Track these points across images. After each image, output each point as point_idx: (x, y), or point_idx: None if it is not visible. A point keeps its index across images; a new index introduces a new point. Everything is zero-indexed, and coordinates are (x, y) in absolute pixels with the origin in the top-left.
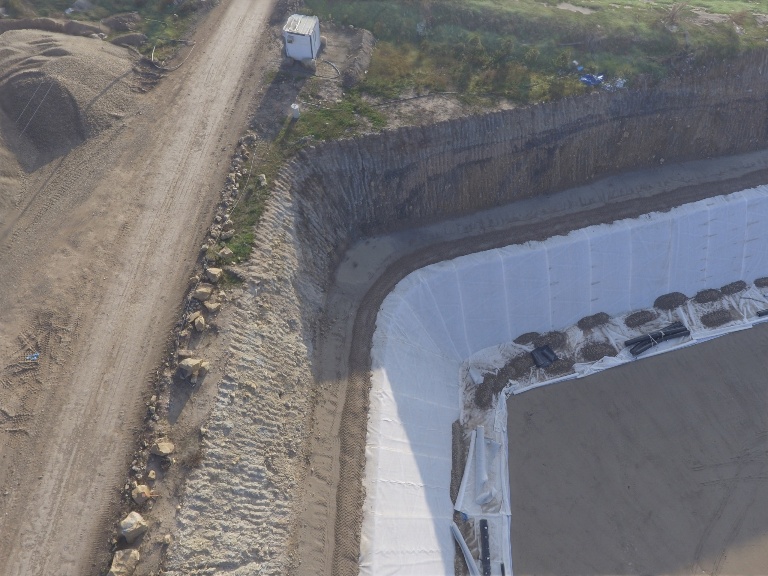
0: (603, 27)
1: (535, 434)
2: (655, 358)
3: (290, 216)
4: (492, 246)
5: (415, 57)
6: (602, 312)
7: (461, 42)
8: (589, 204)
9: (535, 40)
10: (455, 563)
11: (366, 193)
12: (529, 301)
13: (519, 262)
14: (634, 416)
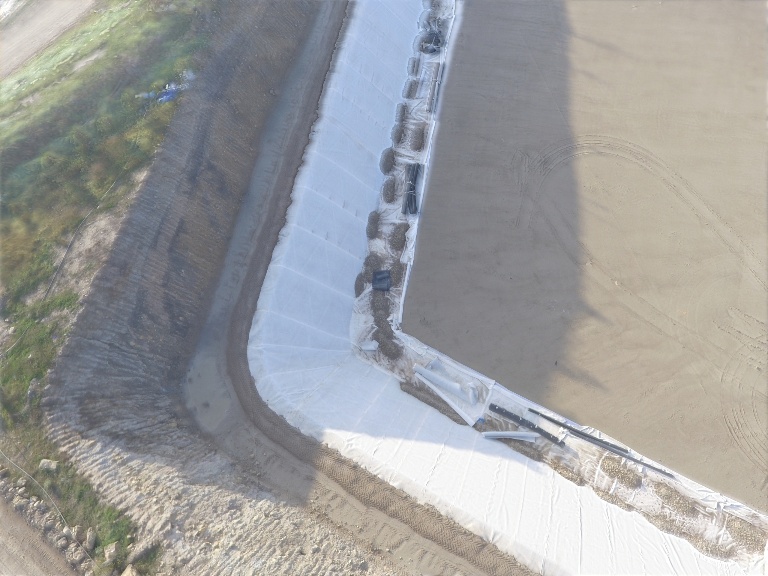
0: (120, 54)
1: (441, 325)
2: (425, 199)
3: (113, 451)
4: (265, 267)
5: (19, 226)
6: (369, 214)
7: (37, 175)
8: (275, 167)
9: (88, 113)
10: (514, 449)
11: (137, 355)
12: (330, 265)
13: (293, 253)
14: (461, 242)
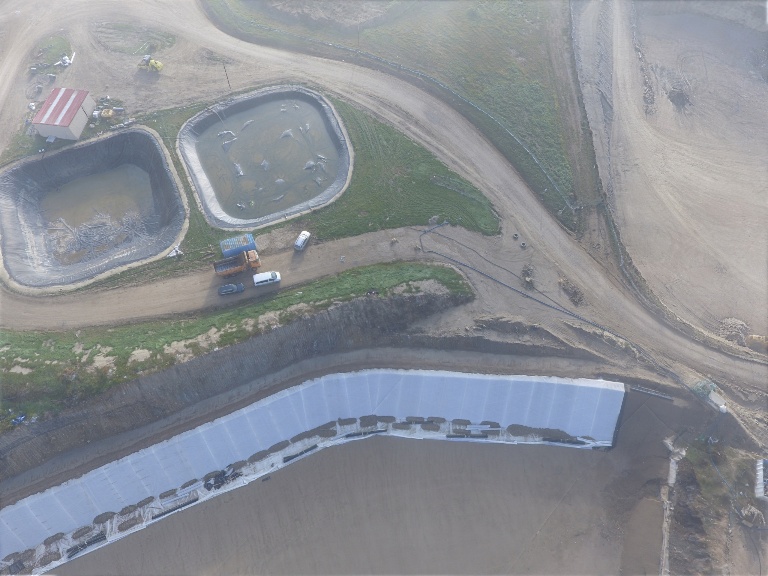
0: (29, 385)
1: None
2: (82, 558)
3: None
4: None
5: None
6: (59, 533)
7: None
8: (36, 480)
9: None
10: None
11: None
12: (2, 540)
13: None
14: None
